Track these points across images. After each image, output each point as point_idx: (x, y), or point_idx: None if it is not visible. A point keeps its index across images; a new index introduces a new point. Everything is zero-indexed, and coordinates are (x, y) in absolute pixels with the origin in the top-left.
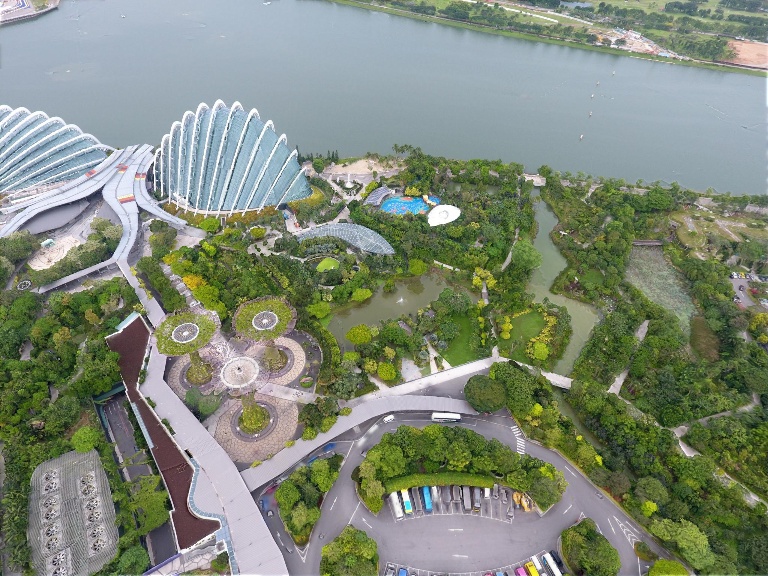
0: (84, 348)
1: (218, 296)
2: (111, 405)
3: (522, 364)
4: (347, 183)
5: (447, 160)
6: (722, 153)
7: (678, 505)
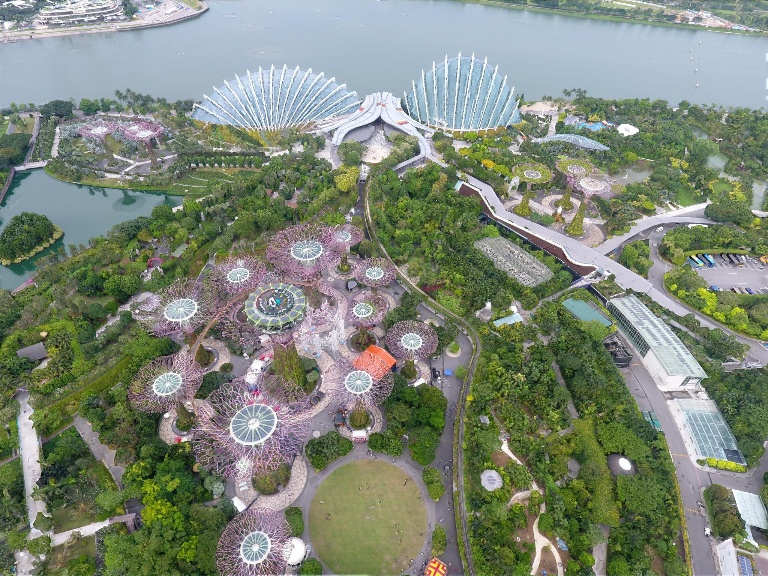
0: None
1: None
2: None
3: None
4: (539, 115)
5: None
6: None
7: None
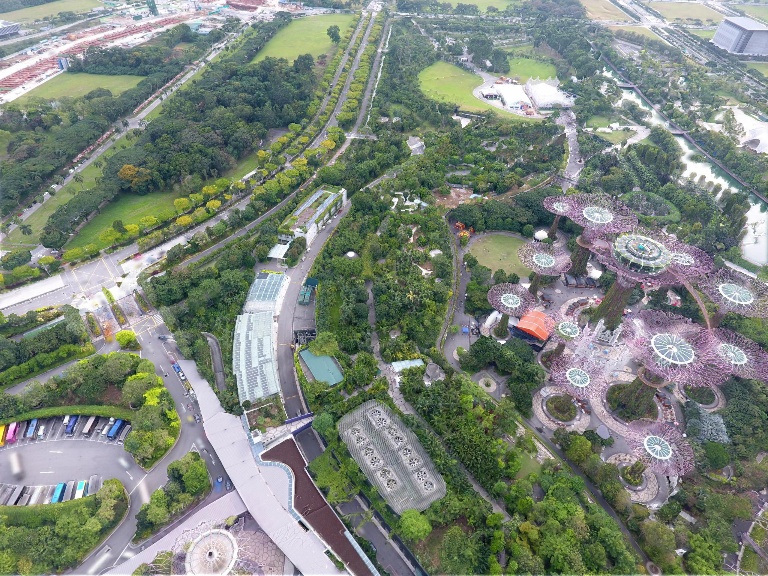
0: None
1: None
2: None
3: None
4: None
5: None
6: None
7: None
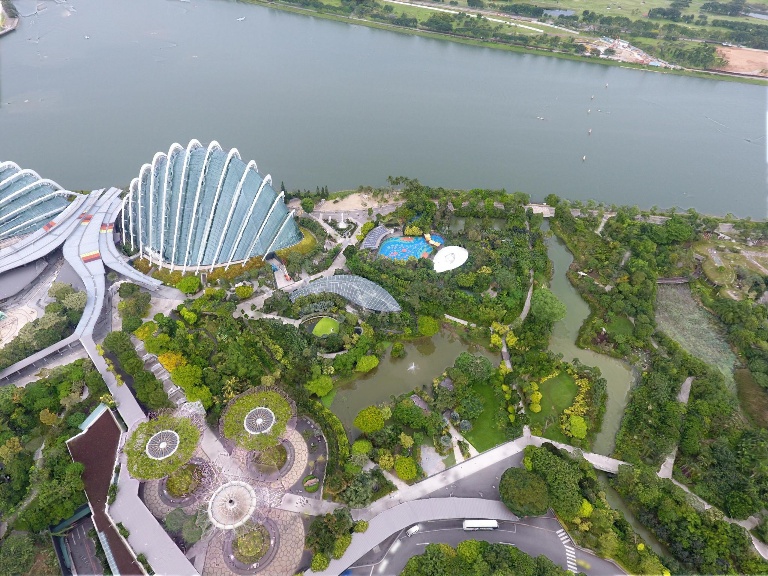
0: (39, 461)
1: (201, 377)
2: (75, 531)
3: (559, 445)
4: (340, 223)
5: (446, 191)
6: (731, 170)
7: None
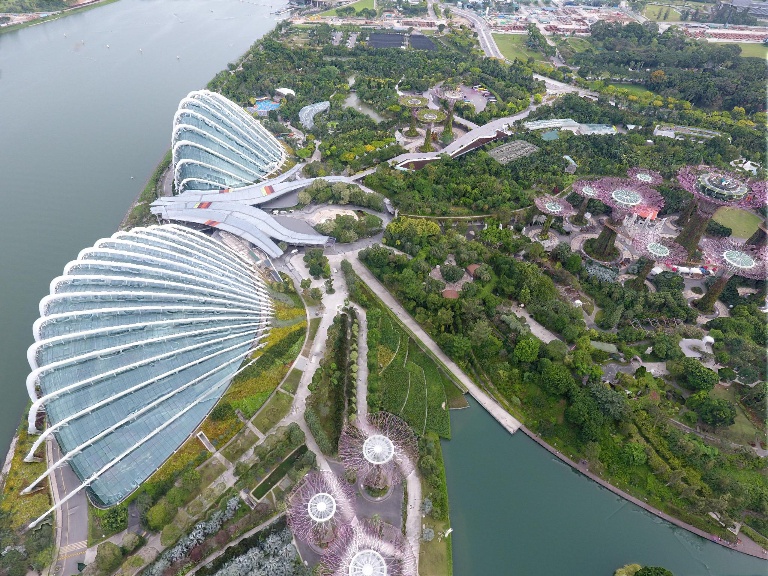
0: None
1: None
2: None
3: None
4: None
5: None
6: (212, 32)
7: (453, 65)
